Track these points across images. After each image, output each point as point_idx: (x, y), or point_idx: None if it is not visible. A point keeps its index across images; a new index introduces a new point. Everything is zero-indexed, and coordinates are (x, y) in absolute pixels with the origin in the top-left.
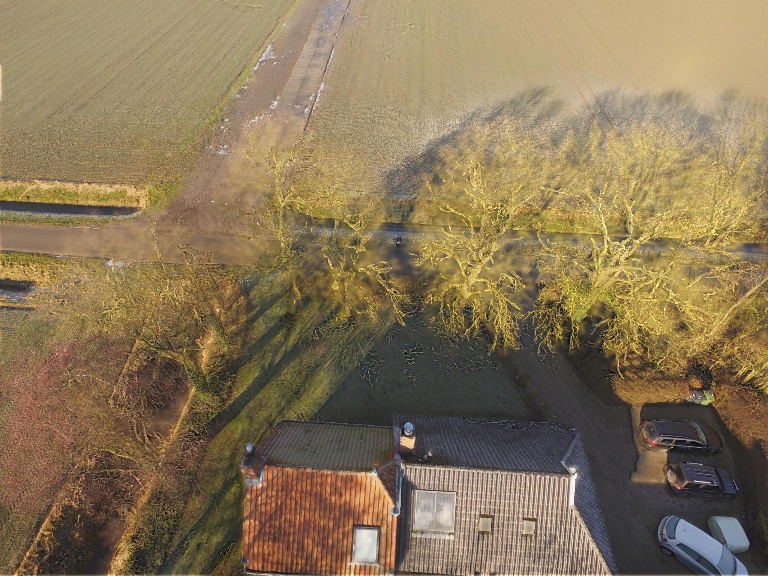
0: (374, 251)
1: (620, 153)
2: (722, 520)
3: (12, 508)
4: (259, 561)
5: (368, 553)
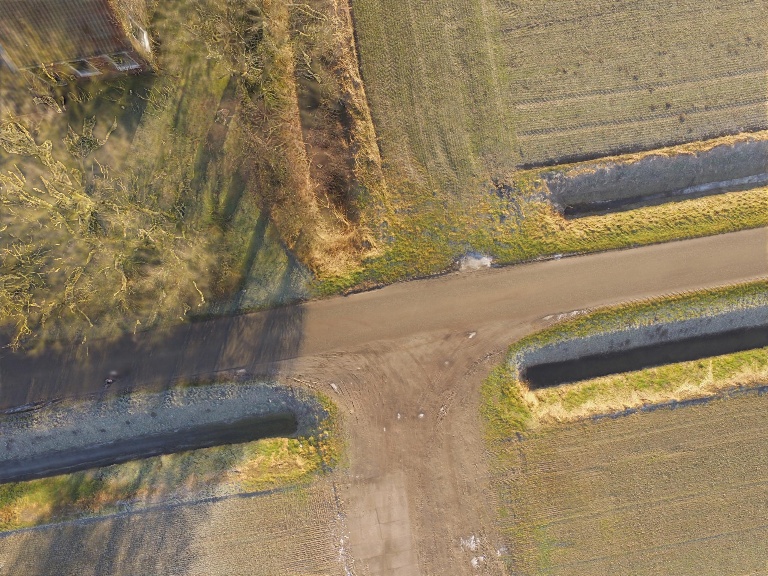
0: (153, 372)
1: None
2: None
3: None
4: None
5: None
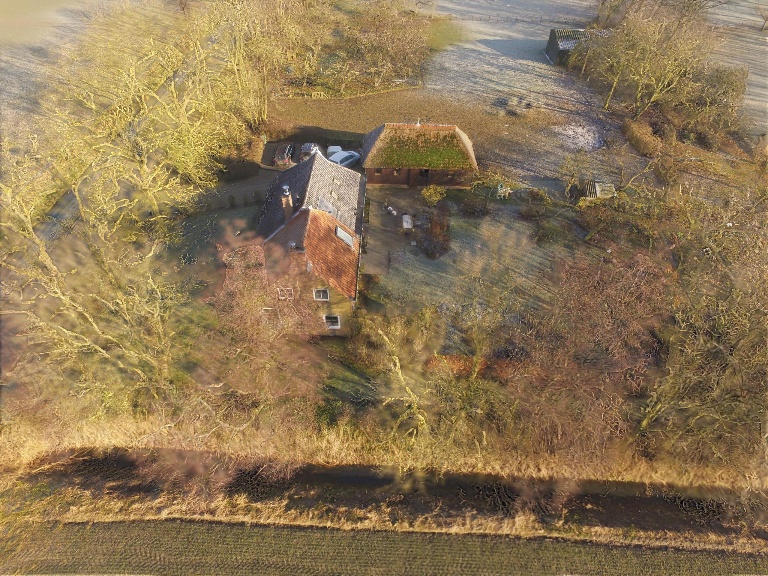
0: None
1: (4, 118)
2: (329, 150)
3: (282, 568)
4: (351, 290)
5: (348, 238)
